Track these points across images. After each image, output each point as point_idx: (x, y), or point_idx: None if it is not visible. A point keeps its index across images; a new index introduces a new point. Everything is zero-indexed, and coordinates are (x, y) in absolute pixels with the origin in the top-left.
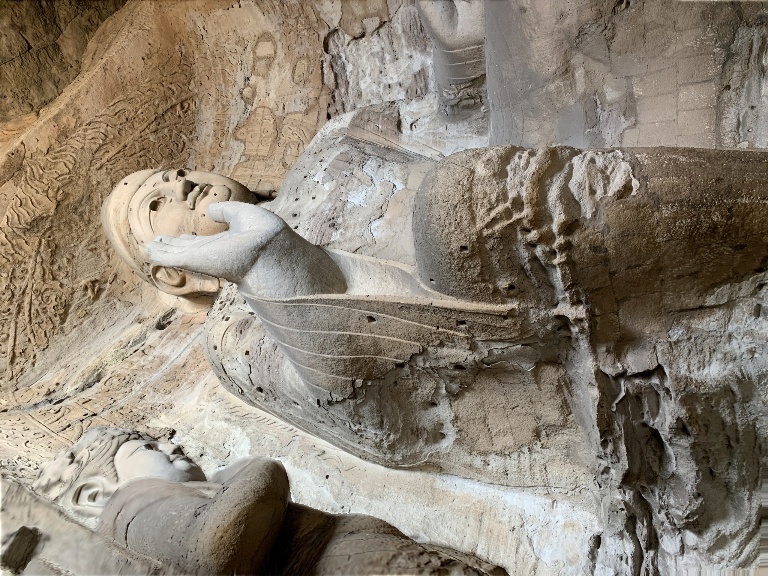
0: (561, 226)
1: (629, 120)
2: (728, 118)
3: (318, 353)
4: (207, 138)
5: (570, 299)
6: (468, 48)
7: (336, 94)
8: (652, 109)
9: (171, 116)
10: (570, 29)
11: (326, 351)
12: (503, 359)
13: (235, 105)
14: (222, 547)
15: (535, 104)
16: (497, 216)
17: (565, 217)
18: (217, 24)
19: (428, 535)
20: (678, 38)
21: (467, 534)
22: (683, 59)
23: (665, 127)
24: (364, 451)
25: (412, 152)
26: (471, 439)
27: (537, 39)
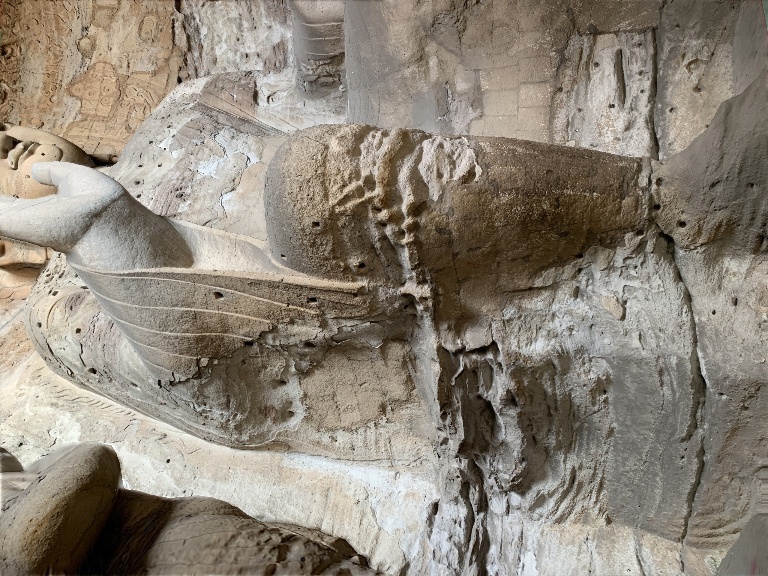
0: (410, 207)
1: (476, 112)
2: (560, 118)
3: (159, 330)
4: (35, 90)
5: (416, 278)
6: (327, 24)
7: (188, 57)
8: (496, 103)
9: None
10: (426, 17)
11: (168, 328)
12: (352, 336)
13: (70, 57)
14: (35, 542)
15: (391, 87)
16: (349, 193)
17: (414, 198)
18: None
19: (274, 514)
20: (521, 38)
21: (313, 510)
22: (524, 59)
23: (507, 121)
24: (209, 432)
25: (268, 126)
26: (319, 416)
27: (394, 23)
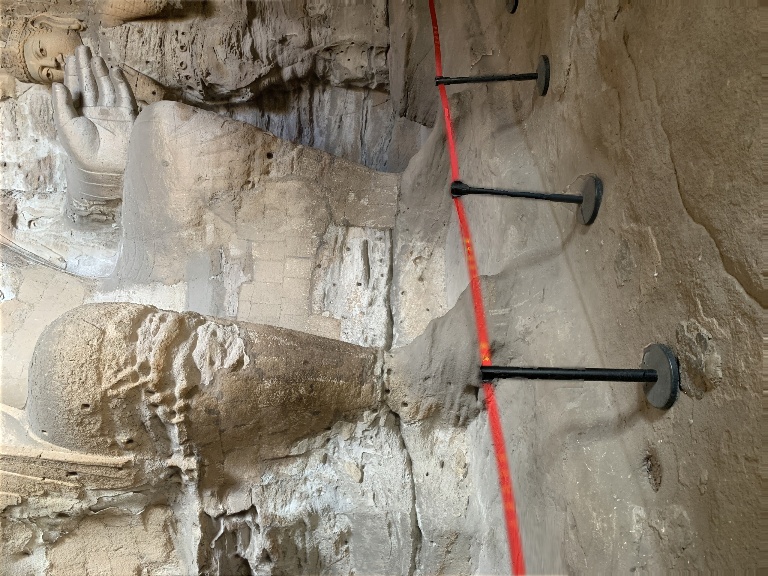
0: (182, 391)
1: (247, 276)
2: (318, 290)
3: None
4: None
5: (184, 452)
6: (107, 173)
7: None
8: (265, 271)
9: None
10: (205, 192)
11: None
12: (112, 505)
13: None
14: None
15: (168, 244)
16: (124, 378)
17: (187, 383)
18: None
19: None
20: (288, 221)
21: None
22: (290, 237)
23: (274, 288)
24: None
25: (27, 251)
26: None
27: (176, 191)
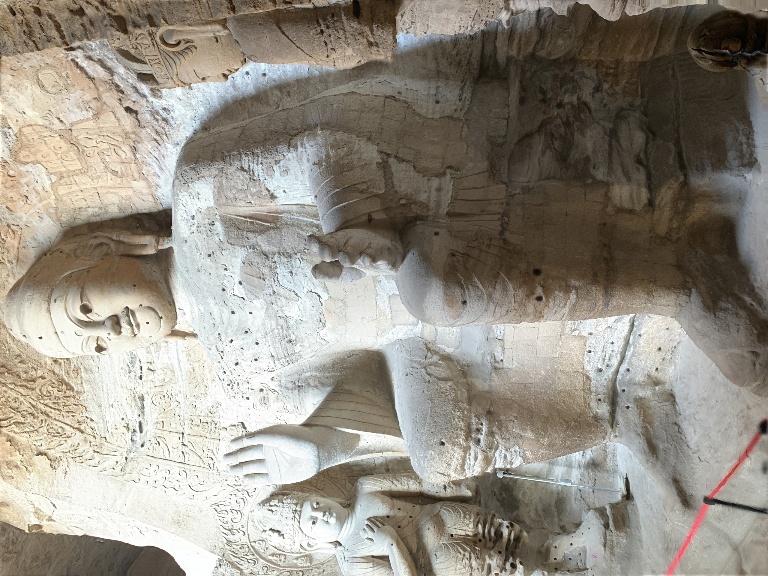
0: None
1: None
2: None
3: None
4: None
5: None
6: None
7: (117, 81)
8: None
9: None
10: None
11: None
12: None
13: None
14: None
15: None
16: None
17: None
18: None
19: None
20: None
21: None
22: None
23: None
24: None
25: (293, 206)
26: None
27: None
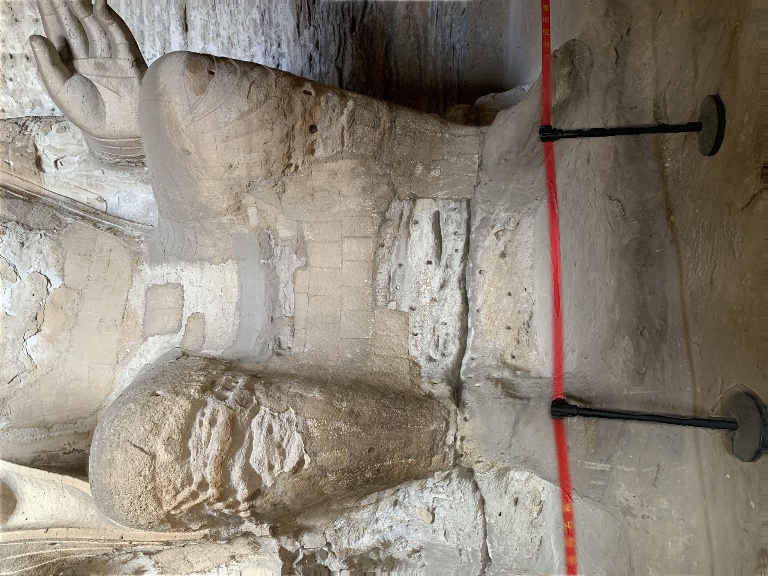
0: (245, 499)
1: (300, 260)
2: (382, 273)
3: None
4: None
5: (256, 524)
6: (122, 140)
7: None
8: (321, 254)
9: None
10: (240, 179)
11: (3, 571)
12: None
13: None
14: None
15: (208, 228)
16: (184, 500)
17: (248, 492)
18: None
19: None
20: (342, 201)
21: None
22: (347, 217)
23: (332, 274)
24: None
25: (62, 196)
26: (173, 570)
27: (205, 180)
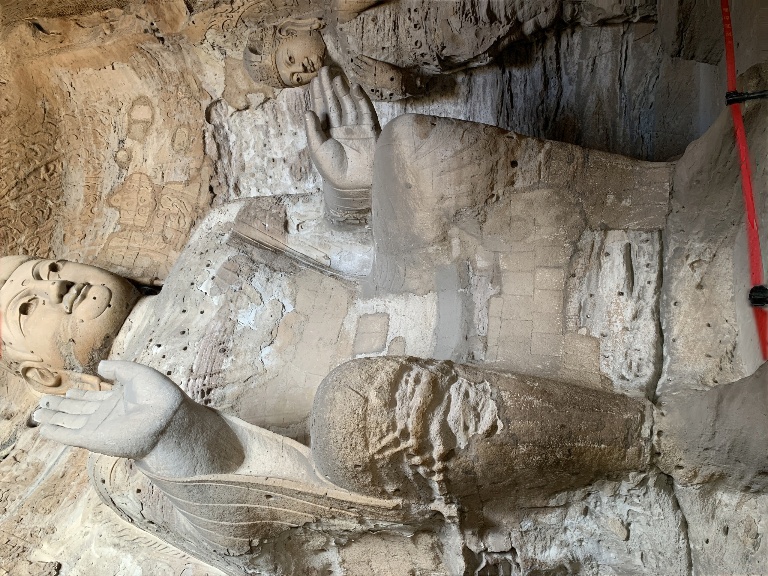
0: (440, 456)
1: (495, 288)
2: (573, 302)
3: (217, 521)
4: (77, 203)
5: (445, 501)
6: (356, 190)
7: (219, 165)
8: (514, 283)
9: (34, 180)
10: (449, 209)
11: (225, 519)
12: (387, 529)
13: (108, 168)
14: None
15: (416, 259)
16: (387, 445)
17: (444, 448)
18: (87, 82)
19: None
20: (537, 231)
21: None
22: (540, 247)
23: (524, 301)
24: None
25: (298, 253)
26: (356, 575)
27: (420, 211)
